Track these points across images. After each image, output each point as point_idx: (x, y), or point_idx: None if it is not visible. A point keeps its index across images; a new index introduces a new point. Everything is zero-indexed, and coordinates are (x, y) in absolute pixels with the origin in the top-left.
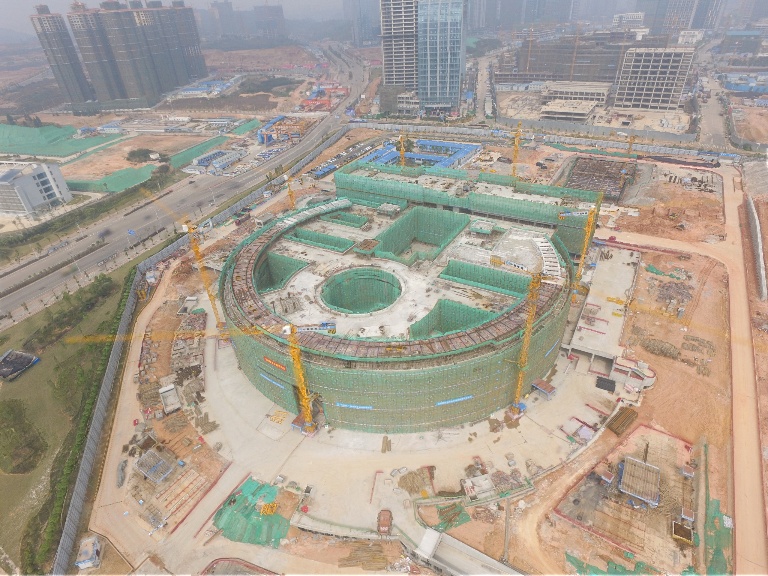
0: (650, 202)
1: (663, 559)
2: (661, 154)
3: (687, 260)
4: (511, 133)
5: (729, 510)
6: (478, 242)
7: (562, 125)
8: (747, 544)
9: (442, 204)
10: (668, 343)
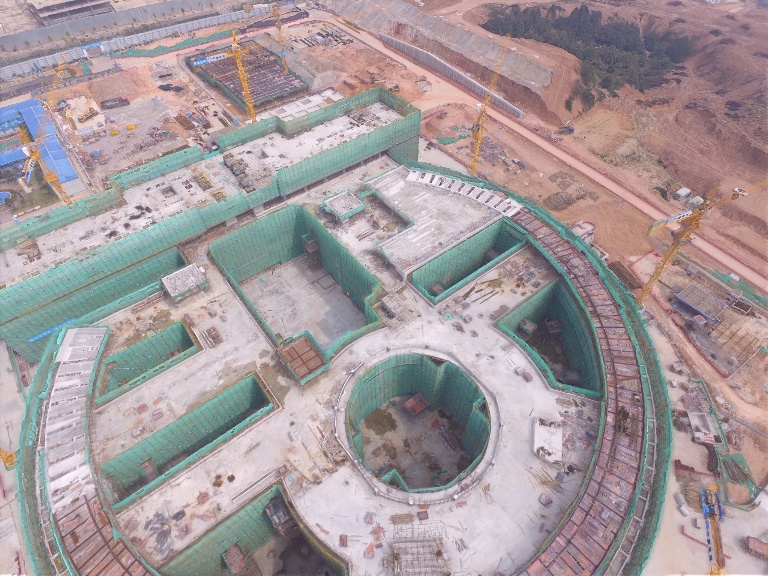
0: (331, 76)
1: (764, 332)
2: (254, 19)
3: (447, 116)
4: (226, 55)
5: (725, 270)
6: (365, 227)
7: (92, 21)
8: (753, 279)
9: (238, 214)
10: (561, 193)
